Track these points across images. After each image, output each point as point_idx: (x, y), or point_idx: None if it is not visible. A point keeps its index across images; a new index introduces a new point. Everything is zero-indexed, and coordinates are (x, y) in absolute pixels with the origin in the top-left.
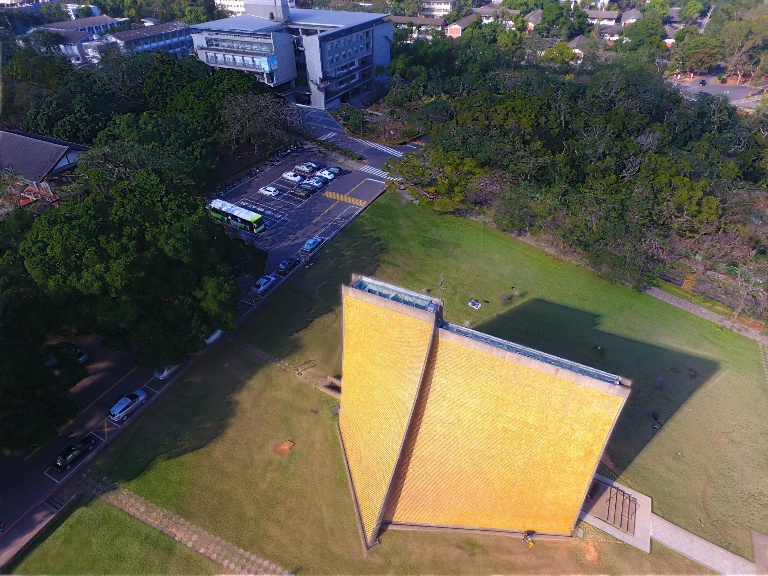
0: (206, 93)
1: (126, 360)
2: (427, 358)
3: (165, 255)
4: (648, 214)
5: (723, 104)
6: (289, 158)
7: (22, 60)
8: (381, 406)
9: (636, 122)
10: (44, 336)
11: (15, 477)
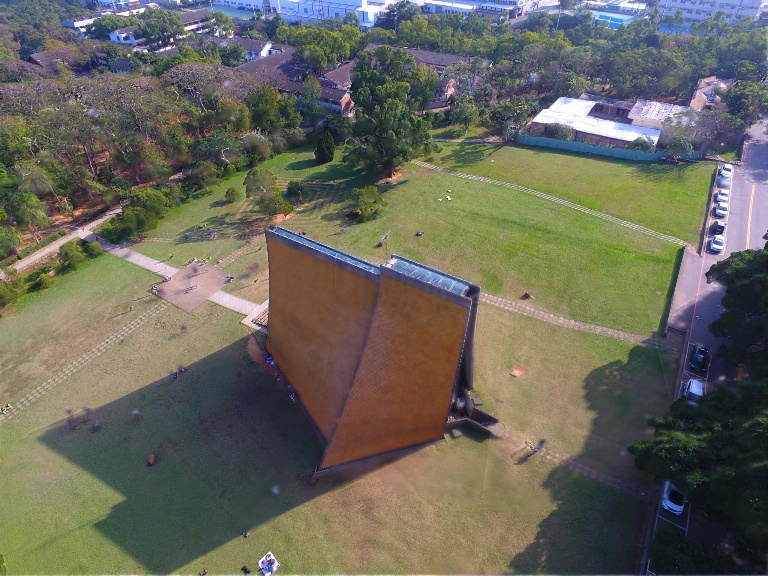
0: None
1: None
2: None
3: None
4: None
5: None
6: None
7: None
8: None
9: None
10: None
11: None
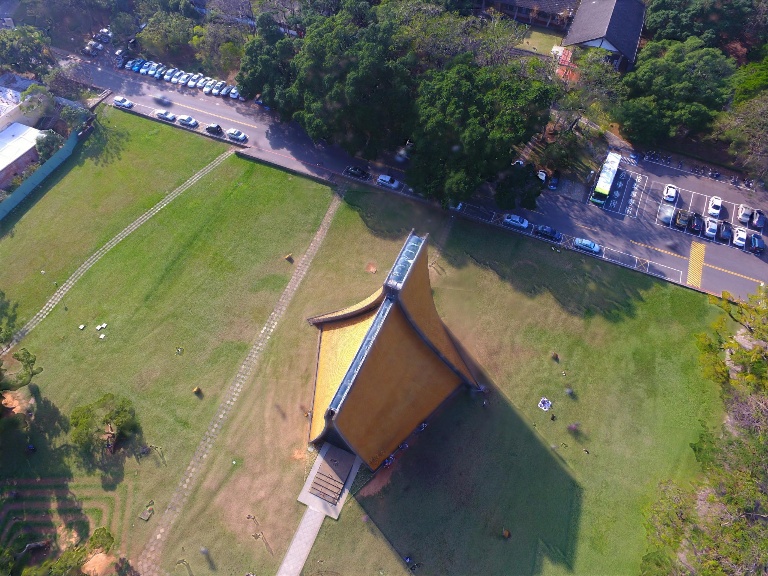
0: None
1: None
2: (375, 300)
3: None
4: None
5: None
6: (764, 195)
7: None
8: None
9: None
10: (404, 120)
11: (345, 157)
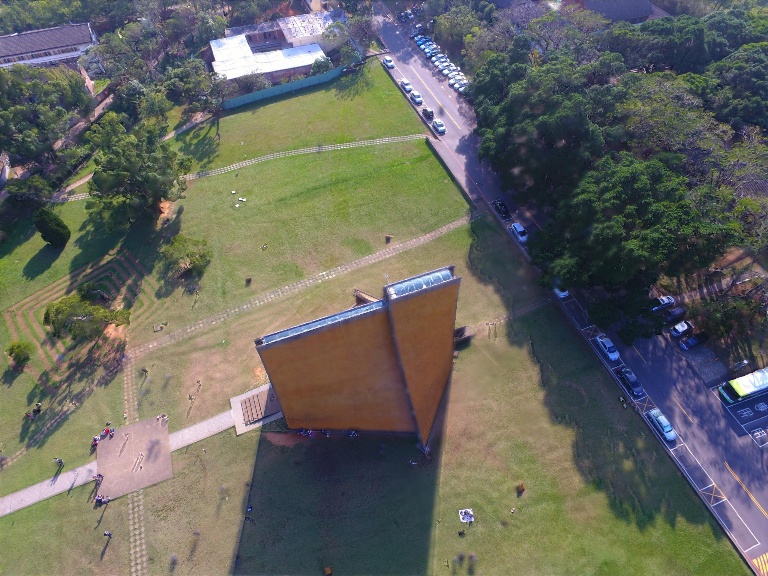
0: None
1: None
2: None
3: None
4: None
5: None
6: None
7: None
8: None
9: None
10: None
11: None
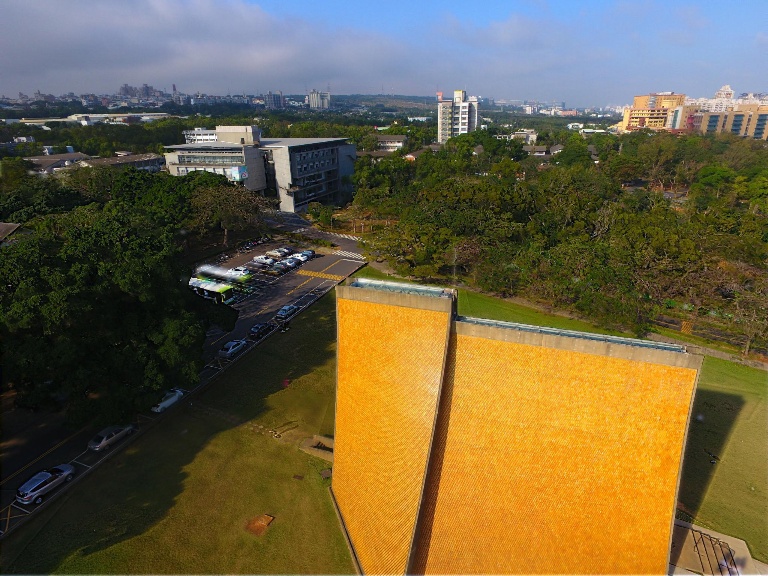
0: (176, 187)
1: (52, 433)
2: (445, 360)
3: (119, 293)
4: (631, 260)
5: (659, 196)
6: (259, 247)
7: None
8: (390, 437)
9: (591, 203)
10: None
11: None
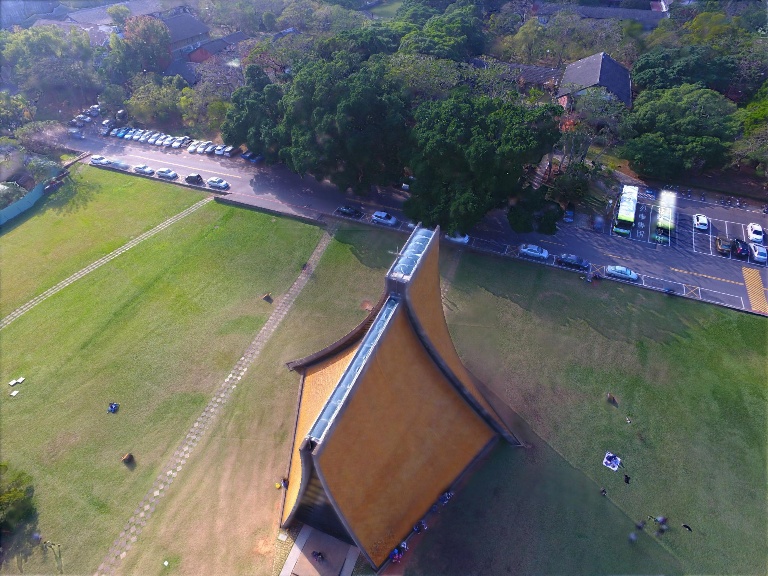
0: None
1: None
2: (374, 309)
3: None
4: None
5: None
6: None
7: (707, 14)
8: None
9: None
10: None
11: (336, 199)
